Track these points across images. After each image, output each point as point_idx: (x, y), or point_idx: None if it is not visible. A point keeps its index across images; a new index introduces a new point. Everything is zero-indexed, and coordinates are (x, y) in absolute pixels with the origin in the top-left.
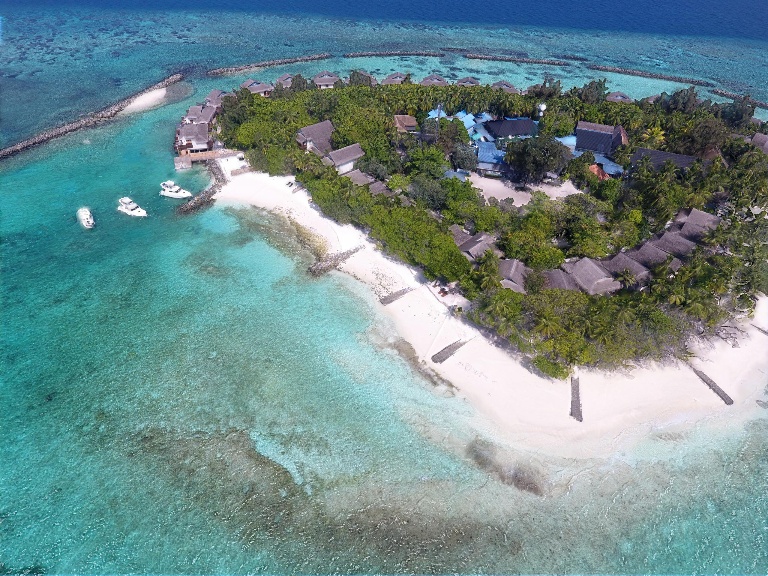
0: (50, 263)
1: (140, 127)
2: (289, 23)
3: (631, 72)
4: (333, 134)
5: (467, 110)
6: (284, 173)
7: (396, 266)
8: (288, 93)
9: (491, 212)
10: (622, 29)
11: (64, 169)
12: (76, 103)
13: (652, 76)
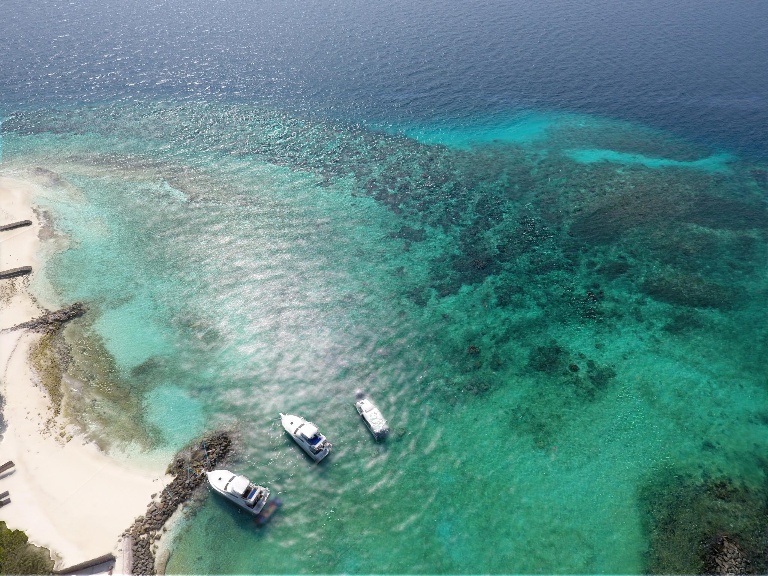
0: (383, 346)
1: None
2: None
3: None
4: None
5: None
6: None
7: None
8: None
9: None
10: None
11: None
12: None
13: None
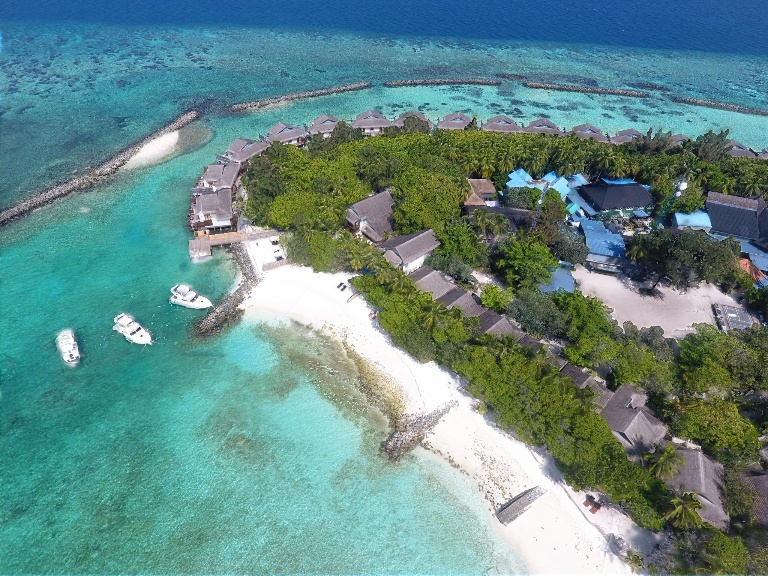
0: (13, 431)
1: (146, 189)
2: (317, 42)
3: (726, 106)
4: (395, 213)
5: (558, 172)
6: (334, 272)
7: (509, 443)
8: (329, 144)
9: (646, 362)
10: (696, 48)
11: (47, 257)
12: (70, 153)
13: (753, 112)
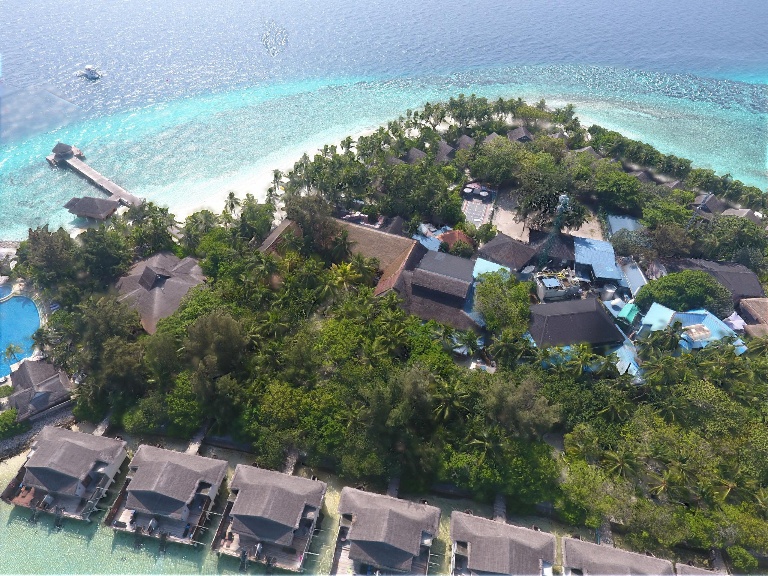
0: None
1: None
2: None
3: None
4: None
5: None
6: None
7: None
8: None
9: None
10: None
11: None
12: None
13: None
